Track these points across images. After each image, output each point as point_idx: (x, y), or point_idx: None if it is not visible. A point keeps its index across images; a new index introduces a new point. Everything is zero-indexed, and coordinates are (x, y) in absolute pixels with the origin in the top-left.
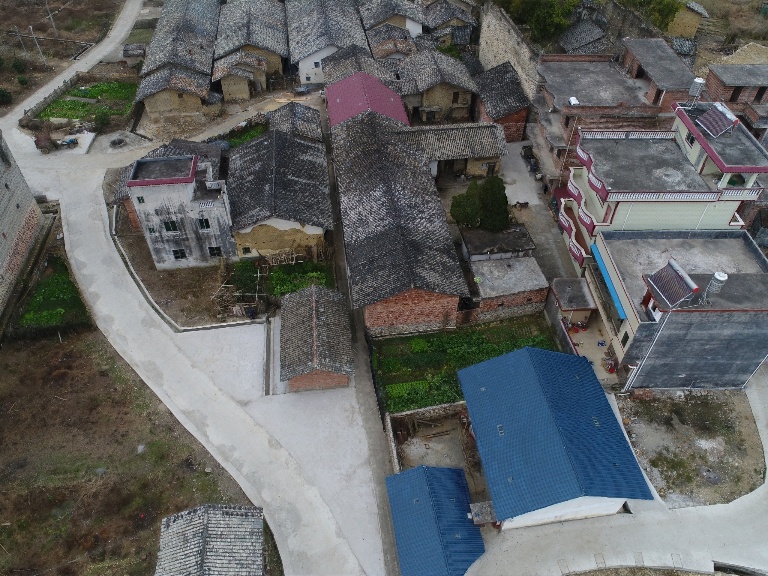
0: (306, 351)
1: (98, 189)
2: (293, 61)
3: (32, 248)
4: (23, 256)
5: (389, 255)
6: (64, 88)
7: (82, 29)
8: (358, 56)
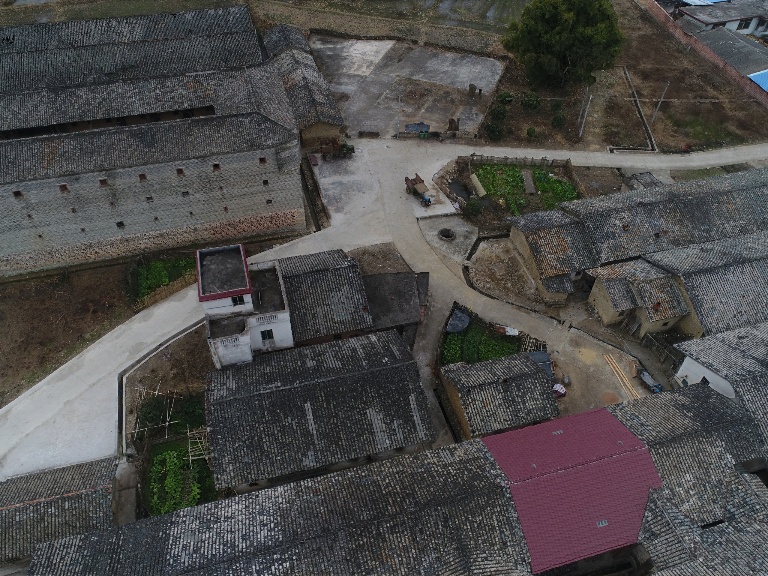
0: (2, 501)
1: (352, 246)
2: (678, 345)
3: (261, 235)
4: (242, 233)
5: (107, 574)
6: (539, 162)
7: (687, 132)
8: (709, 434)
